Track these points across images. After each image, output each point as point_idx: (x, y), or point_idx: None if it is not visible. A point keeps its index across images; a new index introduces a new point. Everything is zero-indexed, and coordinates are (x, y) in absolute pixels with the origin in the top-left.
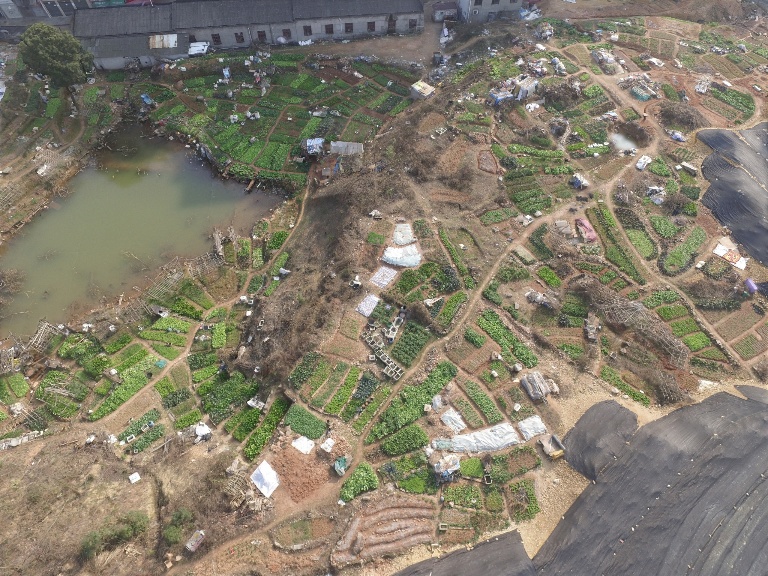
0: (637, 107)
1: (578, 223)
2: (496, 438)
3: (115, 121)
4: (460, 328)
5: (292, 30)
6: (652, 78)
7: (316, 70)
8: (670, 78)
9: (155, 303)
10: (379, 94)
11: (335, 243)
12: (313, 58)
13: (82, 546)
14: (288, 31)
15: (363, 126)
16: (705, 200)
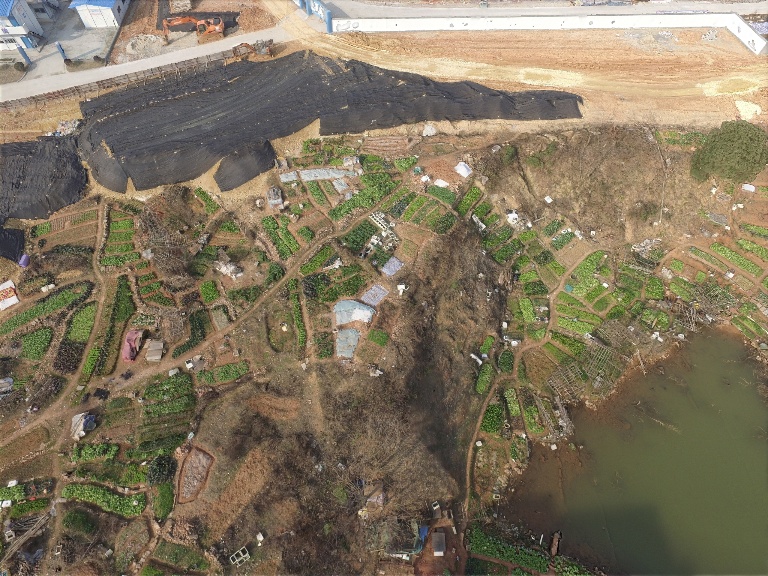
0: None
1: (135, 353)
2: (315, 173)
3: None
4: (316, 243)
5: None
6: None
7: None
8: None
9: None
10: None
11: (423, 357)
12: None
13: (556, 148)
14: None
15: None
16: None
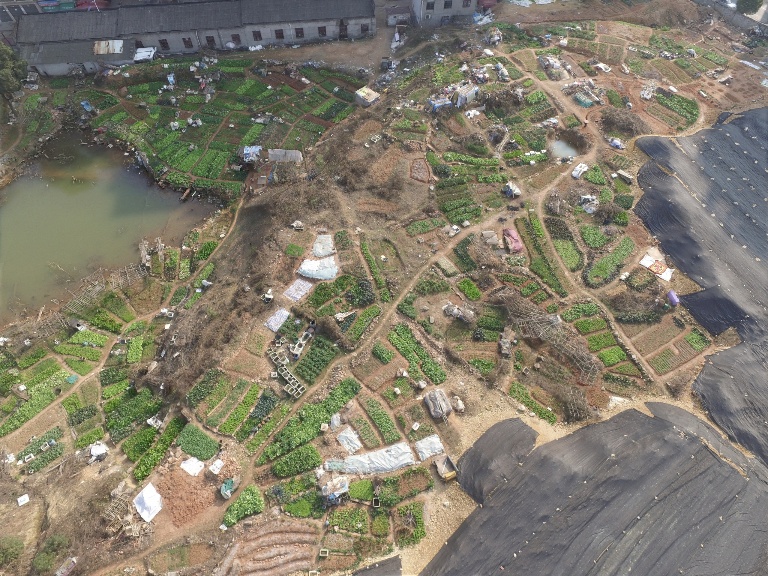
0: (579, 114)
1: (505, 233)
2: (390, 459)
3: (55, 128)
4: (369, 343)
5: (241, 35)
6: (598, 84)
7: (263, 76)
8: (616, 84)
9: (75, 316)
10: (325, 100)
11: (256, 255)
12: (260, 64)
13: None
14: (237, 36)
15: (305, 133)
16: (637, 209)
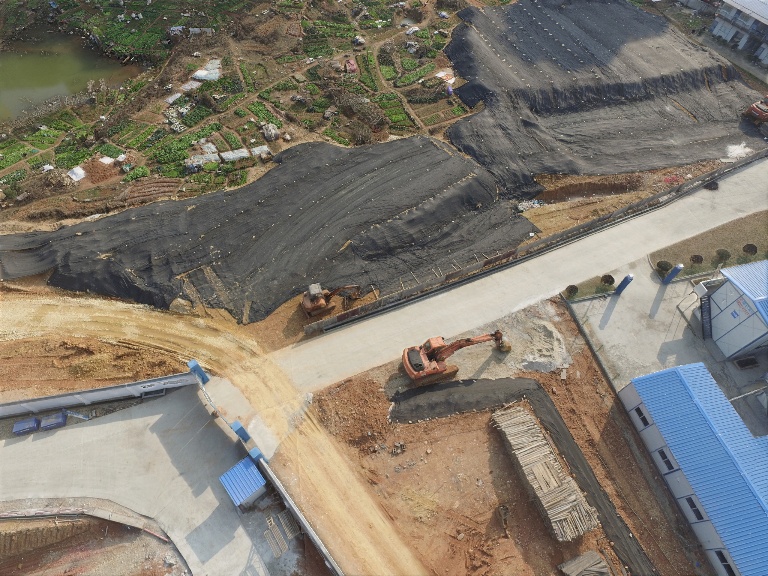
0: None
1: (346, 62)
2: (233, 154)
3: (29, 22)
4: (234, 109)
5: None
6: None
7: None
8: None
9: None
10: (240, 2)
11: None
12: None
13: None
14: None
15: None
16: (445, 49)
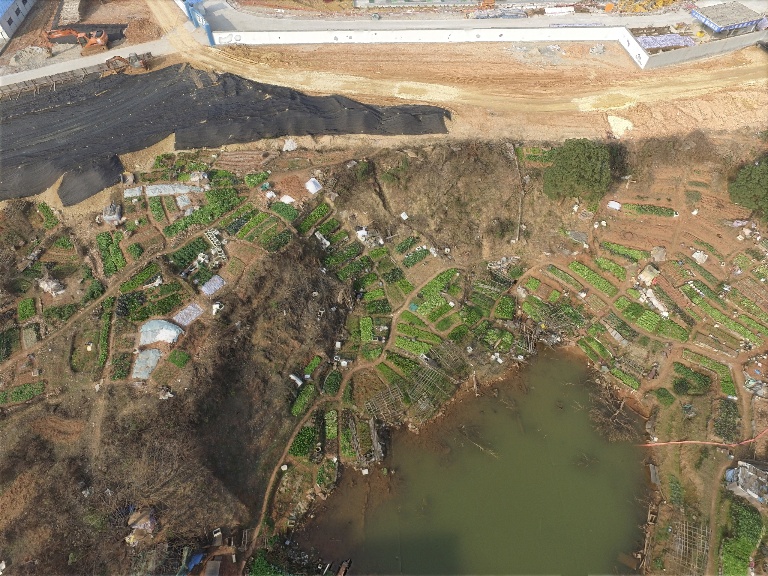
0: None
1: None
2: (161, 188)
3: None
4: (143, 260)
5: None
6: None
7: None
8: None
9: None
10: None
11: (228, 378)
12: None
13: (411, 164)
14: None
15: None
16: None
